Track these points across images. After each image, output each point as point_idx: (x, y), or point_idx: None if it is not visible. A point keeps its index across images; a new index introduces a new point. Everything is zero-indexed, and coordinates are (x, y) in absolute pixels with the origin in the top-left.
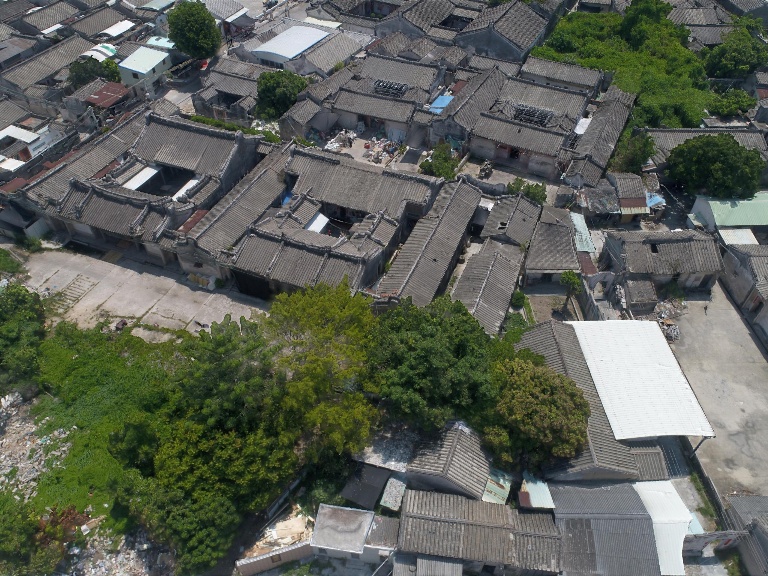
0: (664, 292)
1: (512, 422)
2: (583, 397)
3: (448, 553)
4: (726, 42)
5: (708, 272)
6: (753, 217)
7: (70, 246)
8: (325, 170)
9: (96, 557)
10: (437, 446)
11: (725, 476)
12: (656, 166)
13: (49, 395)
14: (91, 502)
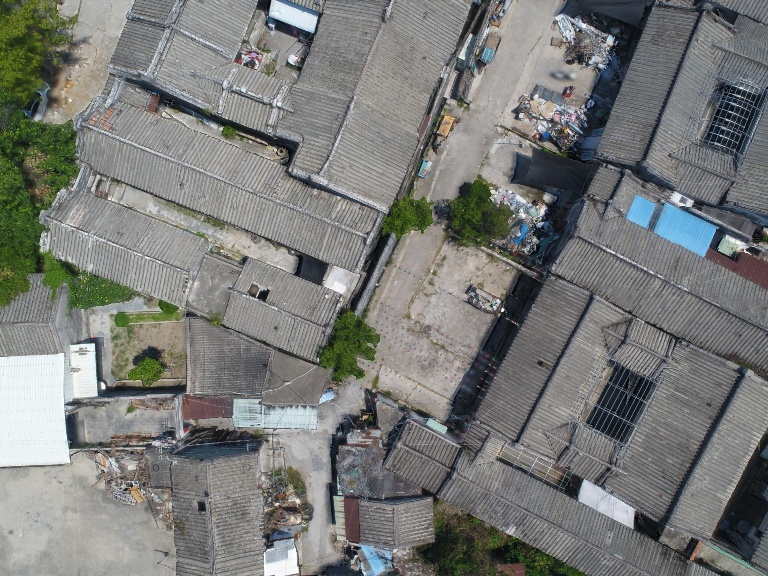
0: None
1: None
2: None
3: None
4: None
5: None
6: None
7: None
8: (376, 1)
9: None
10: None
11: None
12: None
13: None
14: None
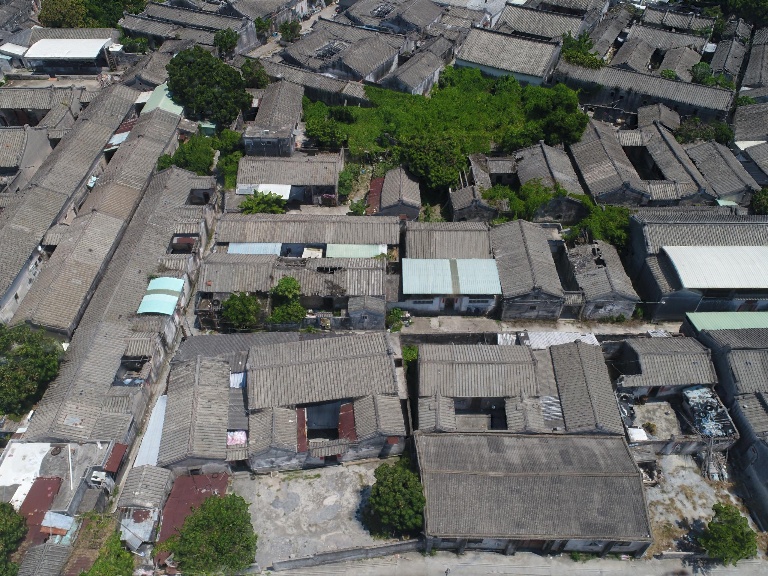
0: None
1: None
2: (54, 15)
3: None
4: None
5: None
6: None
7: None
8: None
9: None
10: None
11: None
12: None
13: None
14: None
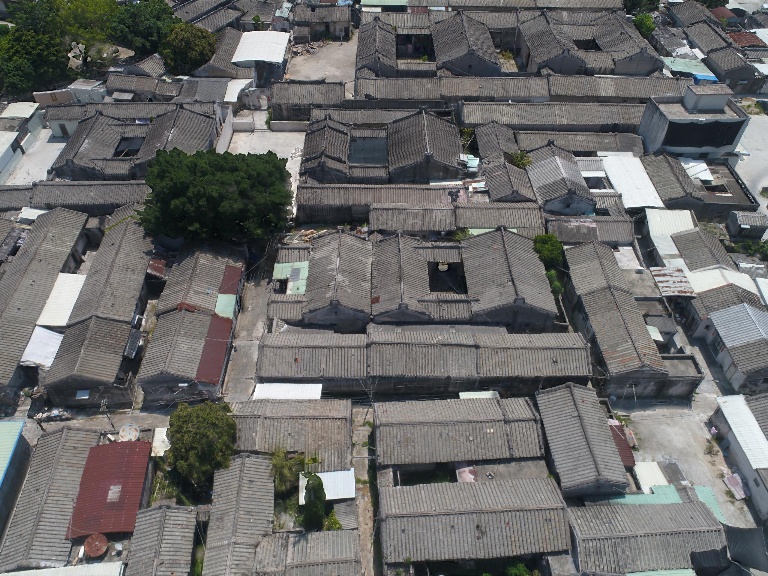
0: (320, 36)
1: (171, 43)
2: (212, 38)
3: (127, 87)
4: None
5: (345, 25)
6: (384, 1)
7: None
8: None
9: None
10: None
11: None
12: None
13: None
14: None
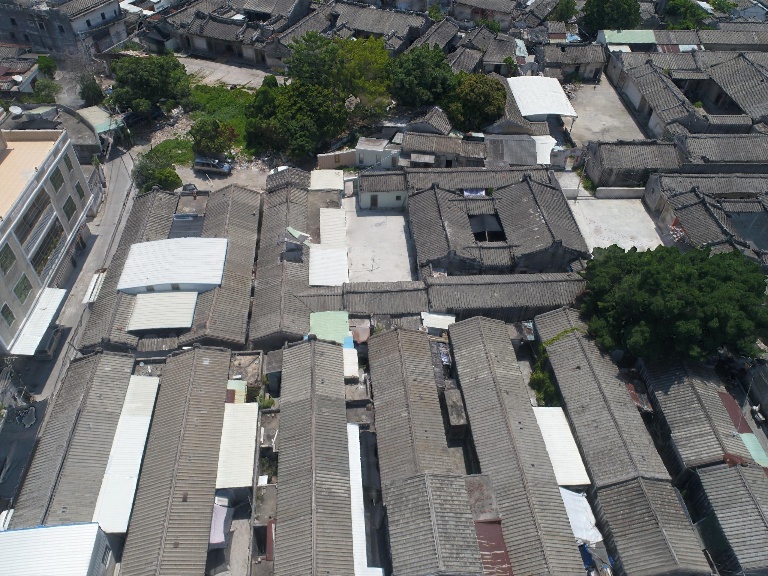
0: (569, 78)
1: (464, 96)
2: None
3: (427, 149)
4: None
5: (597, 66)
6: (630, 38)
7: (192, 56)
8: (357, 11)
9: (240, 163)
10: (423, 115)
11: None
12: (577, 19)
13: (198, 111)
14: (233, 145)
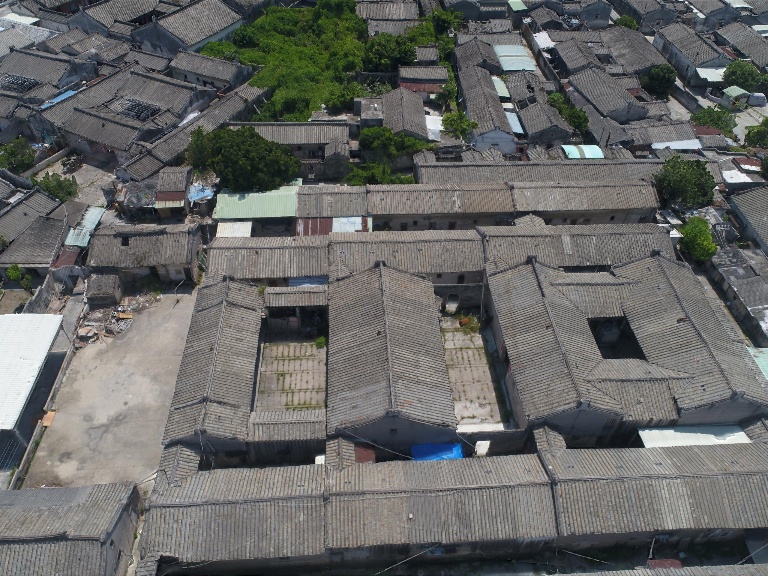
0: (139, 286)
1: None
2: None
3: None
4: (377, 36)
5: (183, 265)
6: (256, 210)
7: None
8: None
9: None
10: None
11: (48, 470)
12: None
13: None
14: None
